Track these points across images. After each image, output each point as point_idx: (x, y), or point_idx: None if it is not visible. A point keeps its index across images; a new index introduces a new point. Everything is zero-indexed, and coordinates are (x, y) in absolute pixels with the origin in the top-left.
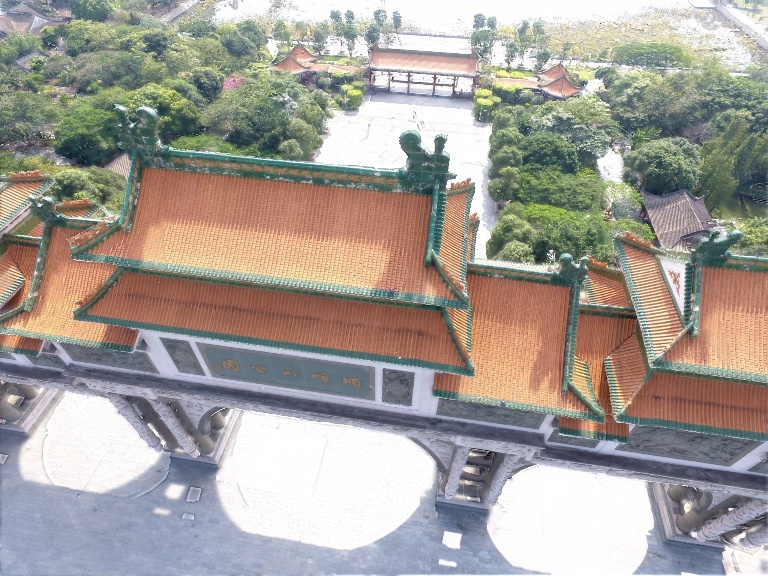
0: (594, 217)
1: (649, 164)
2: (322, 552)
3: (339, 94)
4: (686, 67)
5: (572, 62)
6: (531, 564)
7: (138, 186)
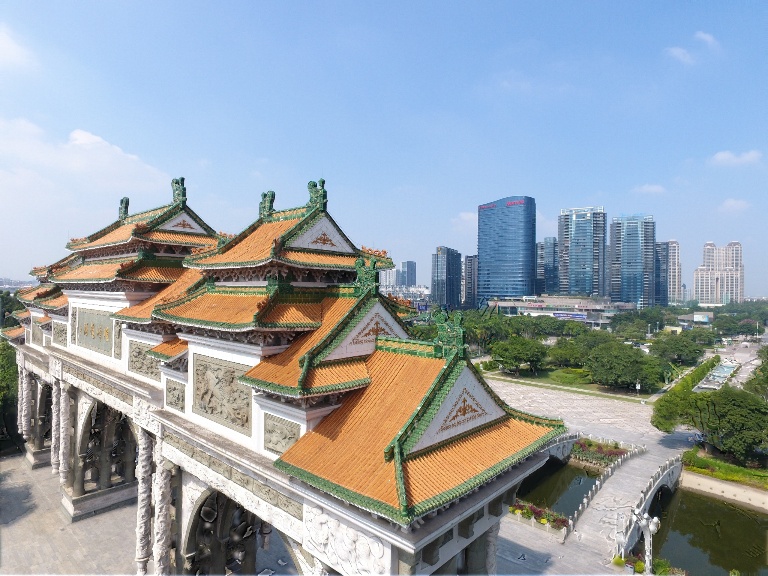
0: None
1: None
2: None
3: None
4: None
5: None
6: None
7: None
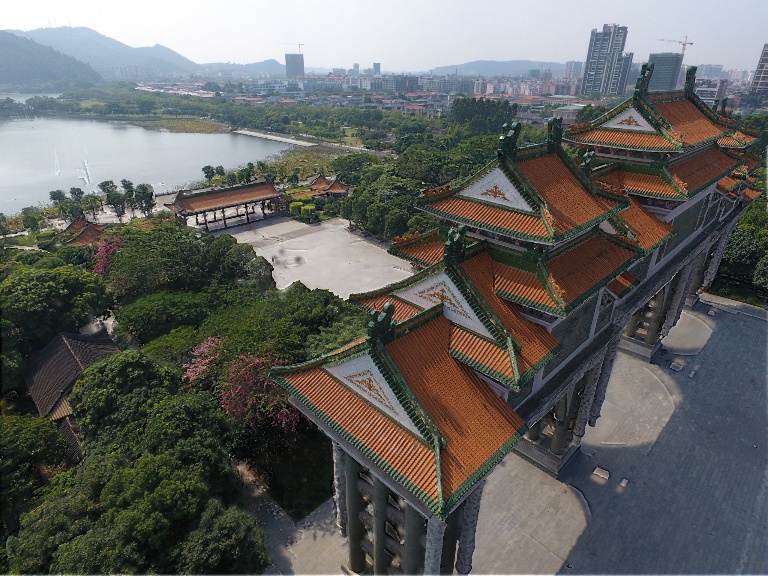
0: None
1: None
2: (674, 420)
3: None
4: None
5: (309, 179)
6: (697, 349)
7: None
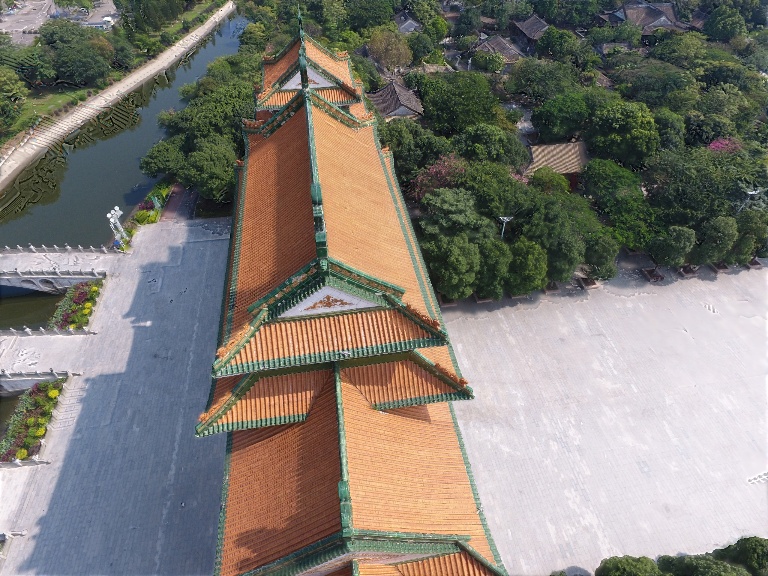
0: None
1: None
2: None
3: None
4: None
5: None
6: None
7: (292, 114)
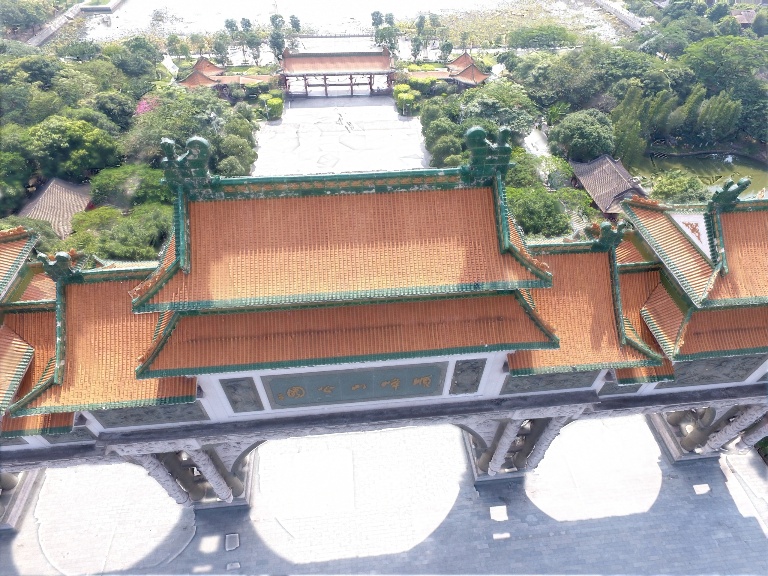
0: (539, 191)
1: (573, 136)
2: (382, 560)
3: (258, 105)
4: (572, 45)
5: (473, 50)
6: (573, 515)
7: (188, 223)
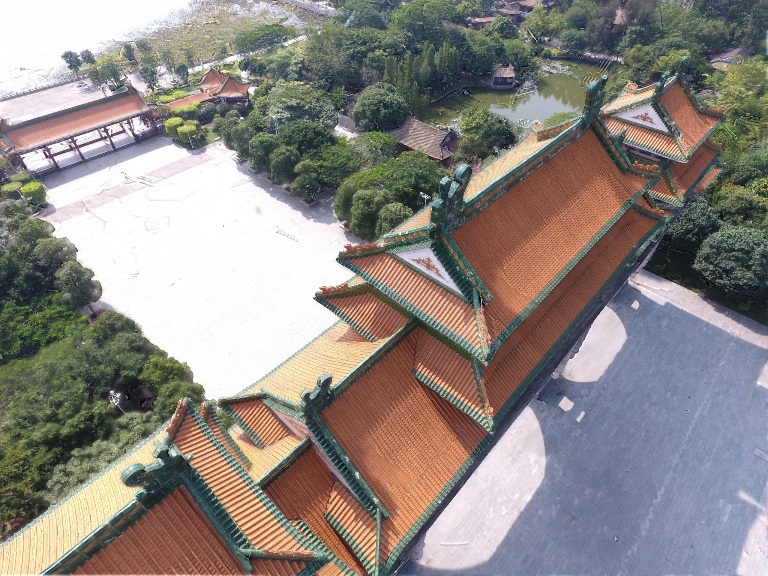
0: (392, 162)
1: (378, 109)
2: (537, 499)
3: None
4: (294, 38)
5: (206, 66)
6: (600, 371)
7: None
